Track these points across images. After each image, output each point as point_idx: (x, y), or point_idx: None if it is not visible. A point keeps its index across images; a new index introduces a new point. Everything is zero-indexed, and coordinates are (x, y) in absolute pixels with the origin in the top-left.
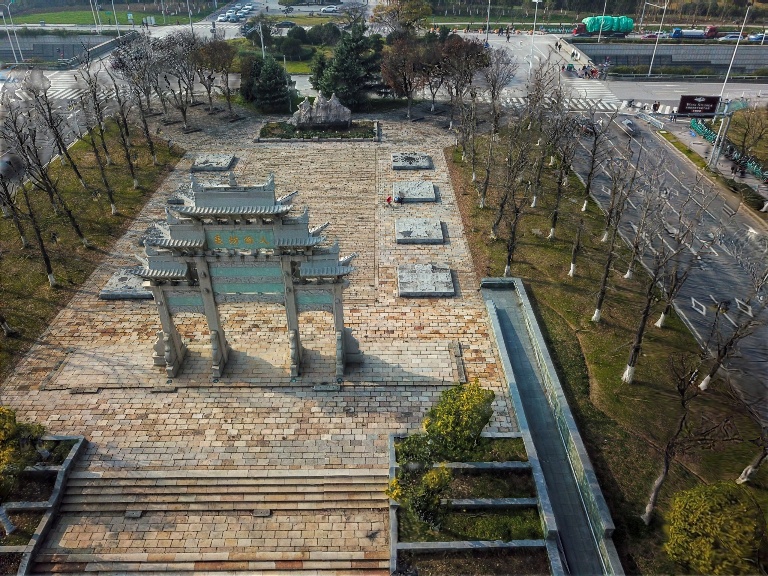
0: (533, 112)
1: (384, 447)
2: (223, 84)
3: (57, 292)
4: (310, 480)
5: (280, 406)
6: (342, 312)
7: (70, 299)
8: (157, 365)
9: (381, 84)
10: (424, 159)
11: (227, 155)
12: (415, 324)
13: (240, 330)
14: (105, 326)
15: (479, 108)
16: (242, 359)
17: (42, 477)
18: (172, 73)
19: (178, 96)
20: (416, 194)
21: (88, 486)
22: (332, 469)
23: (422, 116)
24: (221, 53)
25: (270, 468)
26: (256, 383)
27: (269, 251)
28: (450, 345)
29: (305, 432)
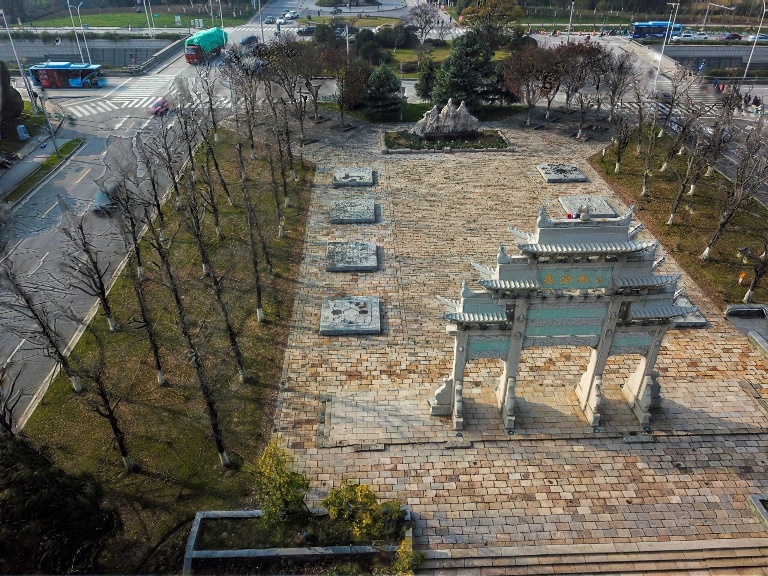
0: (719, 122)
1: (747, 511)
2: (338, 92)
3: (269, 328)
4: (688, 554)
5: (600, 462)
6: (656, 354)
7: (287, 336)
8: (434, 415)
9: (492, 90)
10: (576, 171)
11: (365, 168)
12: (685, 360)
13: (498, 370)
14: (346, 368)
15: (592, 114)
16: (524, 406)
17: (387, 559)
18: (274, 80)
19: (298, 105)
20: (593, 210)
21: (439, 568)
22: (707, 540)
23: (540, 124)
24: (339, 59)
25: (636, 540)
26: (558, 435)
27: (596, 290)
28: (741, 384)
29: (648, 494)
